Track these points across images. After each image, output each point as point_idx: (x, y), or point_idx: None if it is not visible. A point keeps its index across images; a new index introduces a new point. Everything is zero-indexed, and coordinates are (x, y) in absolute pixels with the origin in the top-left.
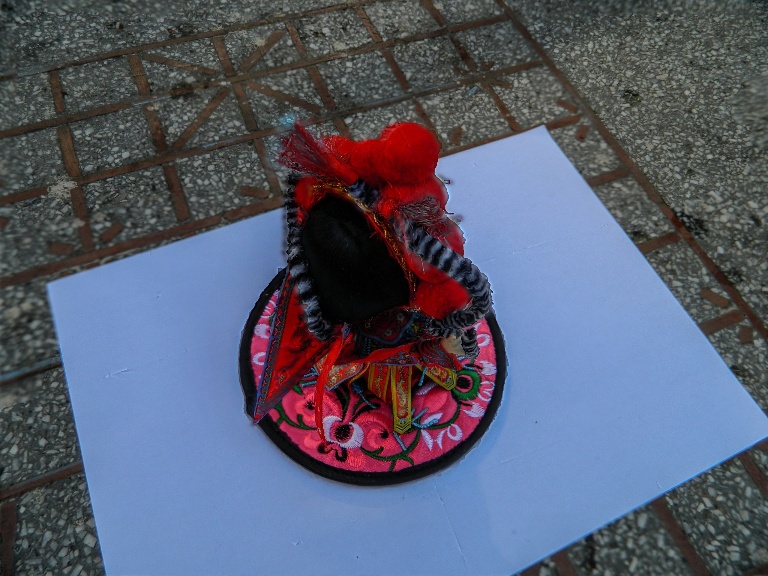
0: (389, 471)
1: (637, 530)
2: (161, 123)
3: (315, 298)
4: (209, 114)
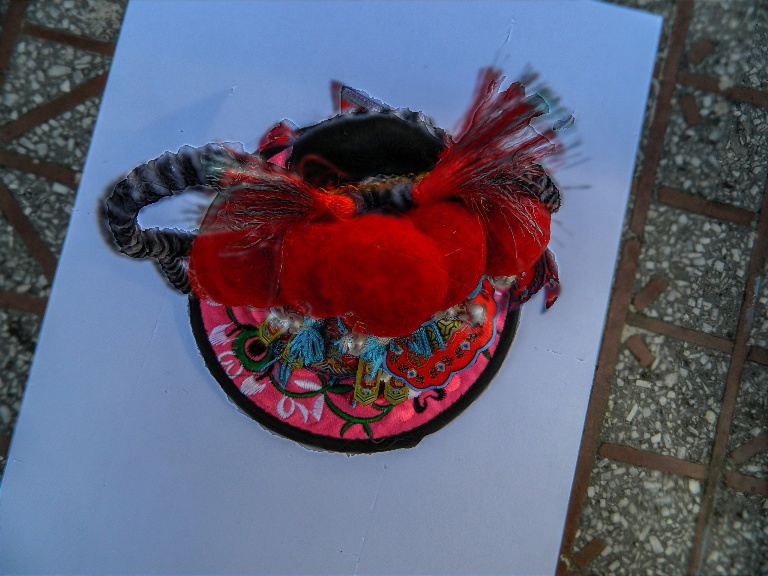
0: None
1: (3, 400)
2: None
3: None
4: None
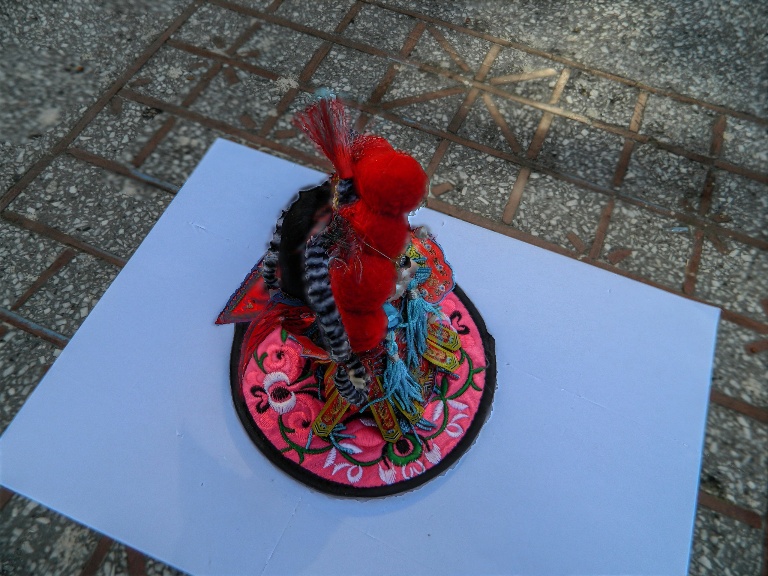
0: (279, 450)
1: None
2: (392, 82)
3: (278, 253)
4: (432, 98)
